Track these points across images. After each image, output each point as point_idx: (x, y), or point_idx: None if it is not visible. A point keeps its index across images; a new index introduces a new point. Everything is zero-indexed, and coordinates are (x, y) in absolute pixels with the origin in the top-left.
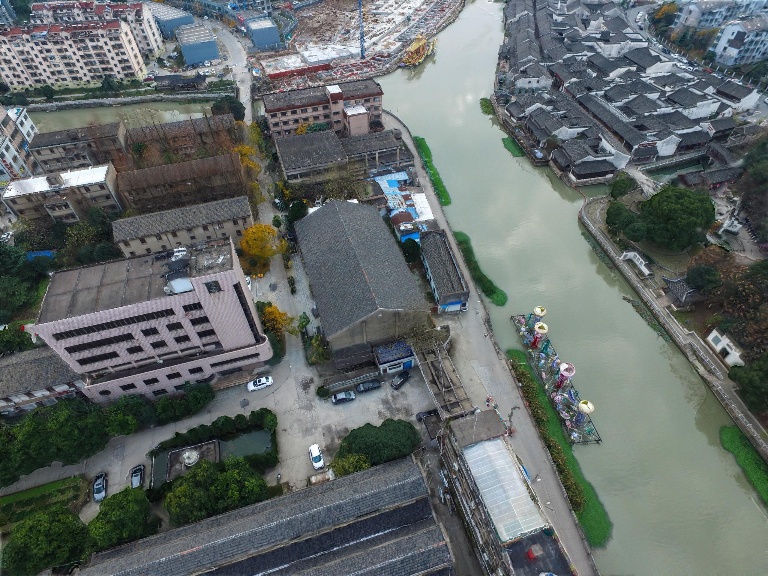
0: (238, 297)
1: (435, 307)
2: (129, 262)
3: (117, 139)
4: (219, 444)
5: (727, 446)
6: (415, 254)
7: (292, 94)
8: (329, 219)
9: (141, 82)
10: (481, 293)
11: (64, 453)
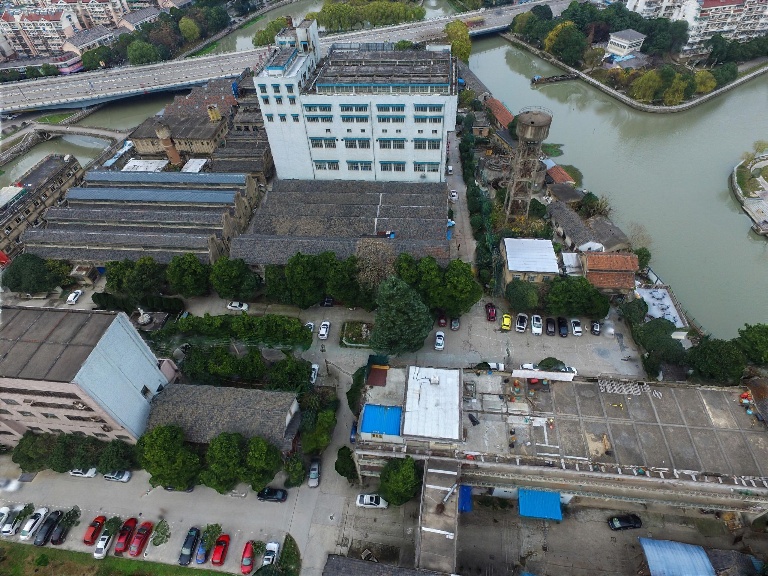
0: None
1: None
2: None
3: None
4: None
5: None
6: None
7: None
8: None
9: None
10: None
11: None
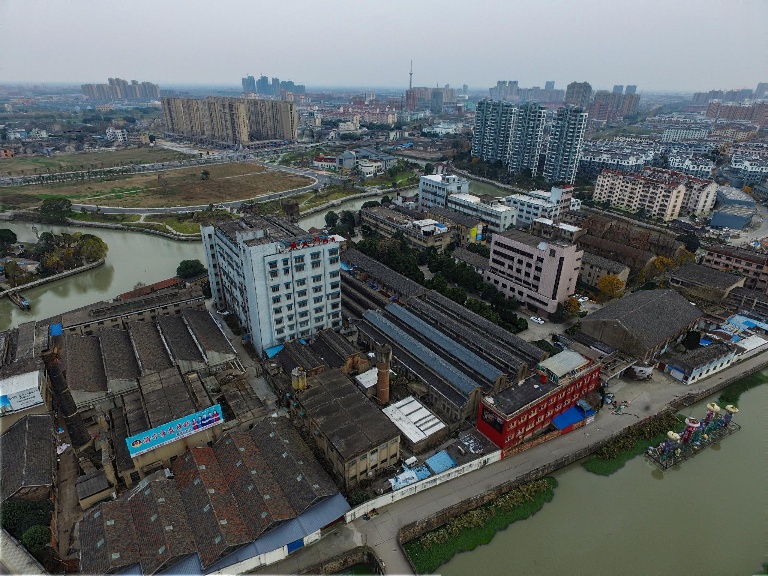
0: (558, 265)
1: (664, 364)
2: (539, 237)
3: (604, 225)
4: (500, 319)
5: (767, 564)
6: (692, 342)
7: (742, 250)
8: (656, 293)
9: (664, 220)
10: (718, 396)
11: (462, 279)
